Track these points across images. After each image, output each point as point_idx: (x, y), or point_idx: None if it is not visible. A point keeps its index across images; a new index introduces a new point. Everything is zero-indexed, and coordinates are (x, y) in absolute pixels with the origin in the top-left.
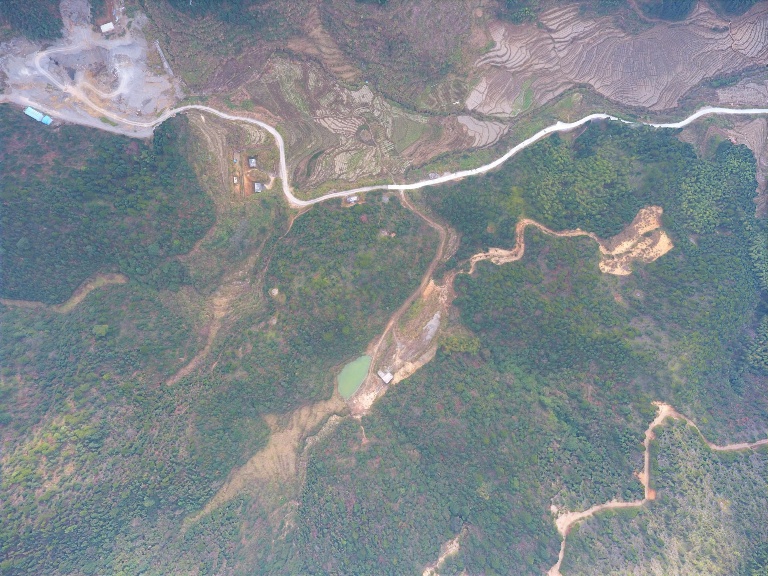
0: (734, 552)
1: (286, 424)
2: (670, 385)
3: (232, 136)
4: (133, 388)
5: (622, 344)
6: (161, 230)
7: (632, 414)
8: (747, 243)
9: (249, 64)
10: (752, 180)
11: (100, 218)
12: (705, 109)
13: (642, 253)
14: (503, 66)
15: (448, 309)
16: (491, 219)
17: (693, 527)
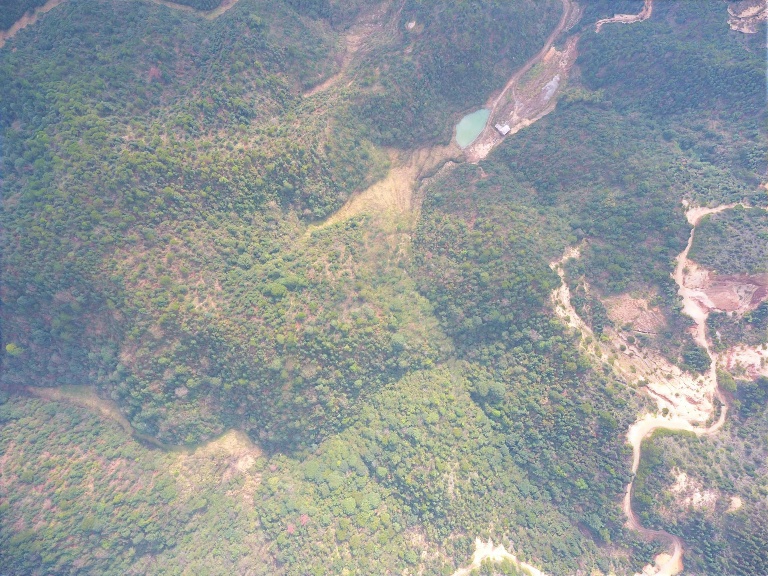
0: None
1: (406, 160)
2: None
3: None
4: (277, 85)
5: (755, 71)
6: None
7: (760, 136)
8: None
9: None
10: None
11: None
12: None
13: None
14: None
15: (569, 70)
16: None
17: None
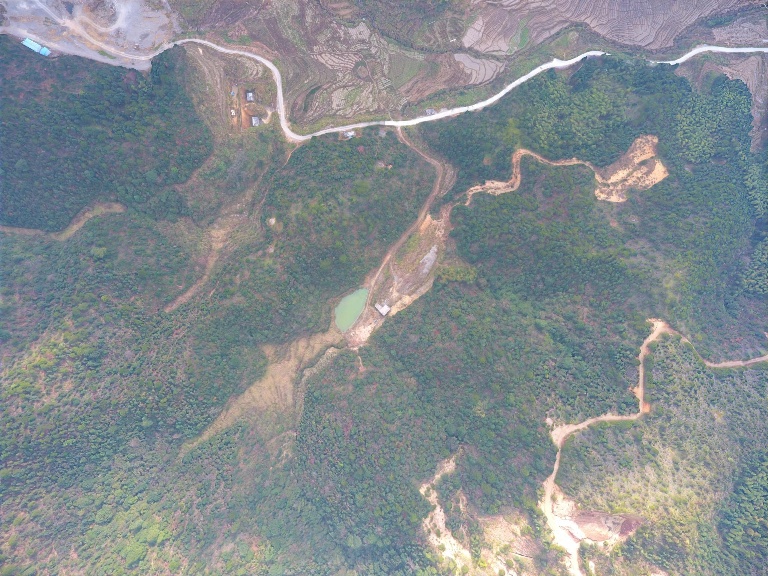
0: (728, 458)
1: (284, 355)
2: (665, 301)
3: (229, 68)
4: (131, 312)
5: (617, 263)
6: (159, 157)
7: (627, 332)
8: (742, 172)
9: (246, 0)
10: (747, 113)
11: (98, 142)
12: (701, 47)
13: (637, 181)
14: (499, 4)
15: (445, 242)
16: (487, 151)
17: (687, 435)
